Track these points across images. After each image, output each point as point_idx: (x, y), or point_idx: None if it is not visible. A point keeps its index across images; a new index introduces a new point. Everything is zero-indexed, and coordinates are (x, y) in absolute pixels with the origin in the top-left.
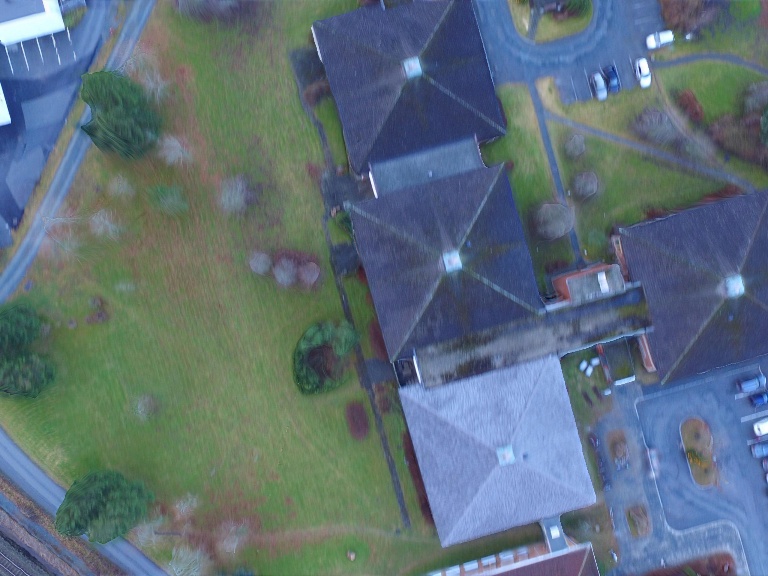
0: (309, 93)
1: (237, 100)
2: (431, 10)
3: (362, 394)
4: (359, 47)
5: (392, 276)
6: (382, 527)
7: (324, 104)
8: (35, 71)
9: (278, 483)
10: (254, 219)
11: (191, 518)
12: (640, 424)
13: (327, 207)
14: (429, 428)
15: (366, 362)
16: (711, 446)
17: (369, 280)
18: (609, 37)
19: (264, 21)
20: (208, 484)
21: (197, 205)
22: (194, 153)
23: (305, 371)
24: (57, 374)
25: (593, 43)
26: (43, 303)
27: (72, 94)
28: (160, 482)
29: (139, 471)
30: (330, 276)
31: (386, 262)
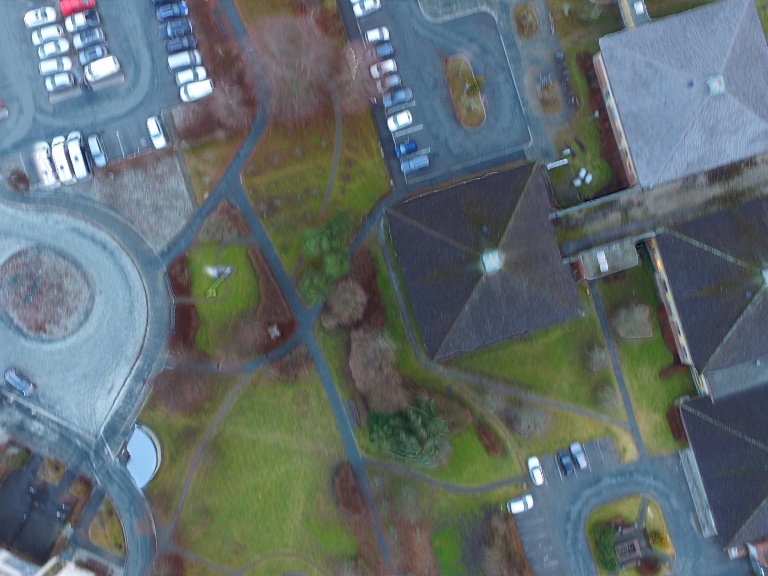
0: None
1: None
2: (764, 520)
3: None
4: None
5: None
6: None
7: None
8: None
9: None
10: None
11: None
12: (527, 120)
13: None
14: None
15: None
16: None
17: None
18: (569, 504)
19: None
20: None
21: None
22: None
23: None
24: None
25: (584, 497)
26: None
27: None
28: None
29: None
30: None
31: None
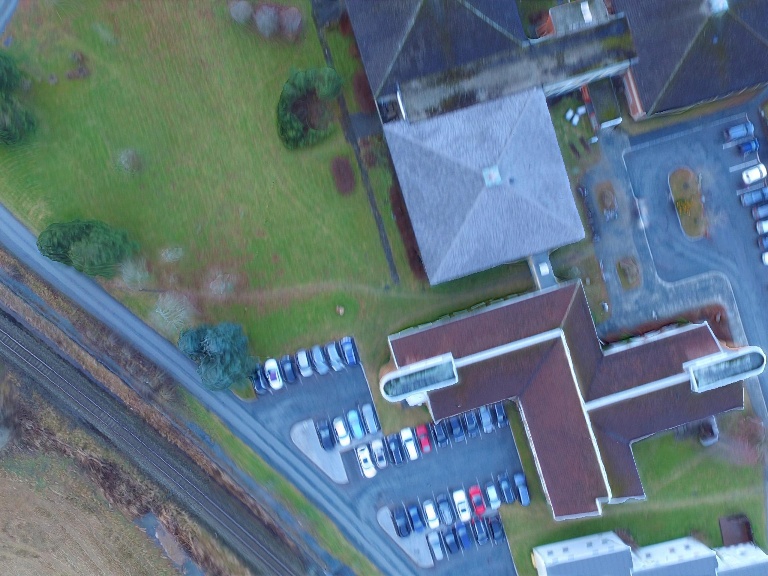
0: None
1: None
2: None
3: (347, 149)
4: None
5: (373, 7)
6: (371, 283)
7: None
8: None
9: (265, 240)
10: None
11: (177, 275)
12: (628, 175)
13: None
14: (414, 161)
15: (351, 116)
16: (699, 185)
17: (351, 15)
18: None
19: None
20: (194, 242)
21: None
22: None
23: (289, 116)
24: (39, 129)
25: None
26: (23, 59)
27: None
28: (145, 239)
29: (124, 224)
30: (312, 30)
31: None
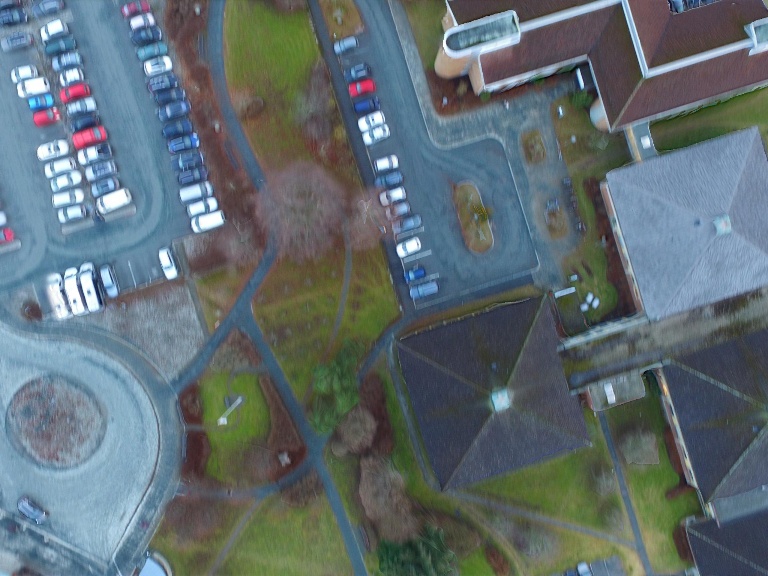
0: None
1: None
2: None
3: None
4: None
5: None
6: None
7: None
8: None
9: None
10: None
11: None
12: (534, 245)
13: None
14: None
15: None
16: None
17: None
18: None
19: None
20: None
21: None
22: None
23: None
24: None
25: None
26: None
27: None
28: None
29: None
30: None
31: None
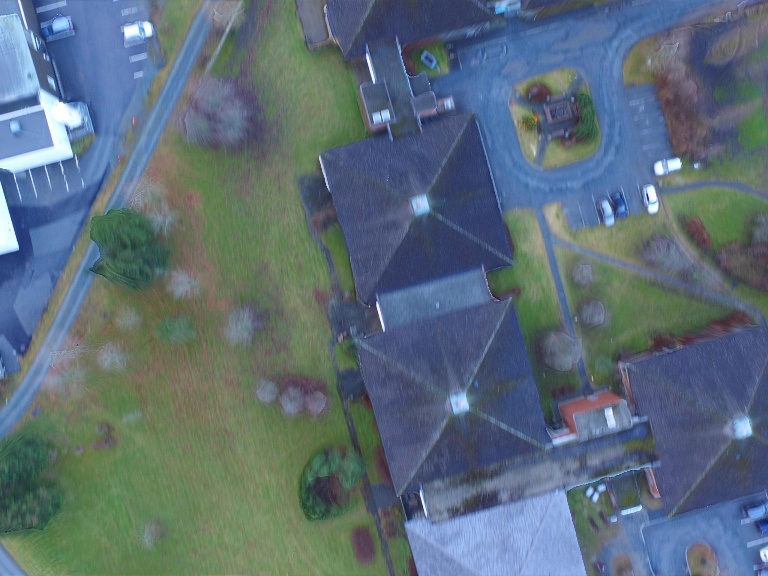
0: (316, 221)
1: (244, 226)
2: (439, 143)
3: (368, 519)
4: (367, 181)
5: (399, 412)
6: None
7: (331, 230)
8: (43, 198)
9: None
10: (261, 344)
11: None
12: (646, 549)
13: (334, 332)
14: (435, 564)
15: (372, 487)
16: None
17: (376, 414)
18: (617, 163)
19: (272, 147)
20: None
21: (204, 331)
22: (201, 279)
23: (311, 501)
24: (64, 500)
25: (601, 169)
26: (50, 429)
27: (80, 221)
28: None
29: None
30: (337, 401)
31: (393, 398)
